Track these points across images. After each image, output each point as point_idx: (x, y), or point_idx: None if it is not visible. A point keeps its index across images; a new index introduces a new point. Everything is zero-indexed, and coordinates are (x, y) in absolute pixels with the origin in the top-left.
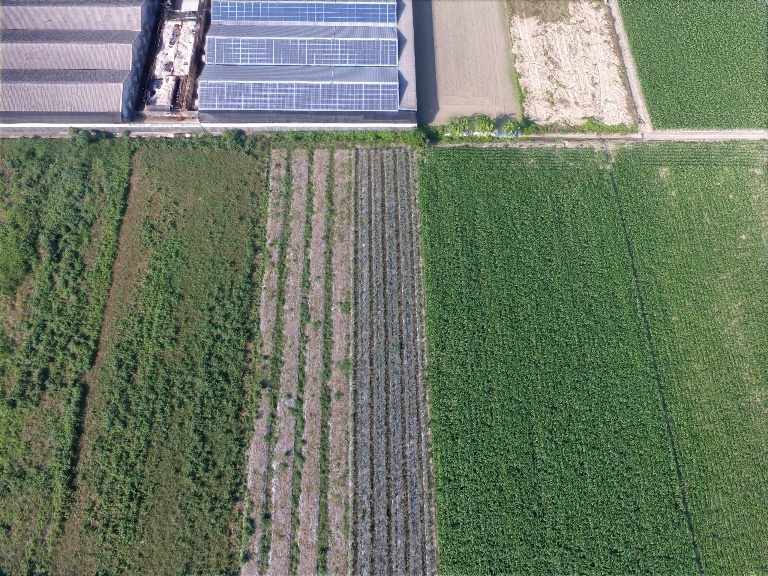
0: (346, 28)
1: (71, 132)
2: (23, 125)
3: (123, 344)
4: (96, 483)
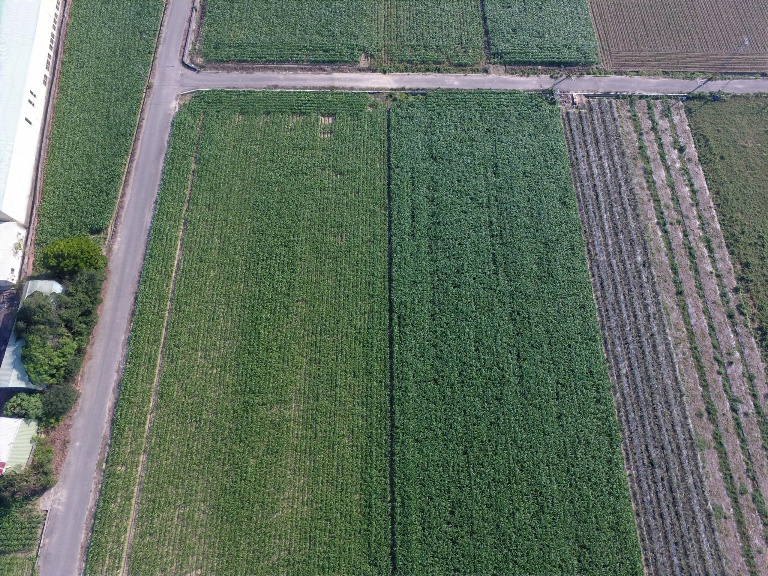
0: None
1: None
2: None
3: None
4: None
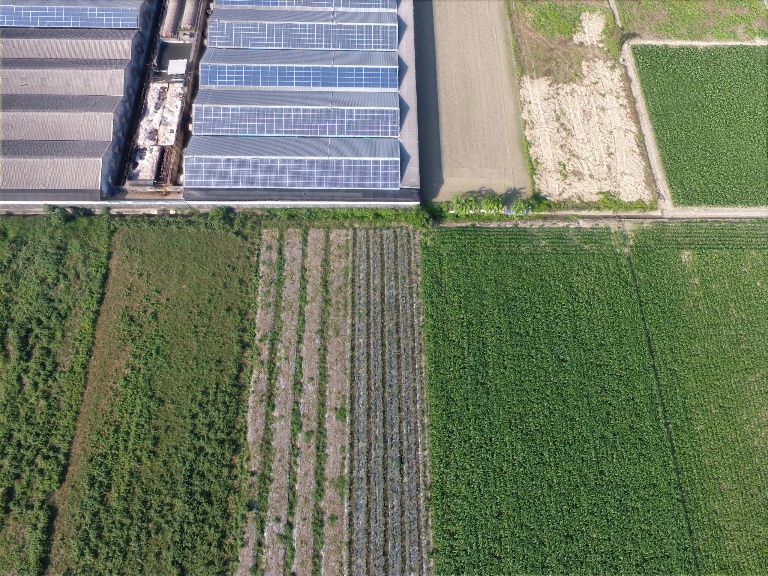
0: (344, 94)
1: (46, 210)
2: None
3: (96, 458)
4: None
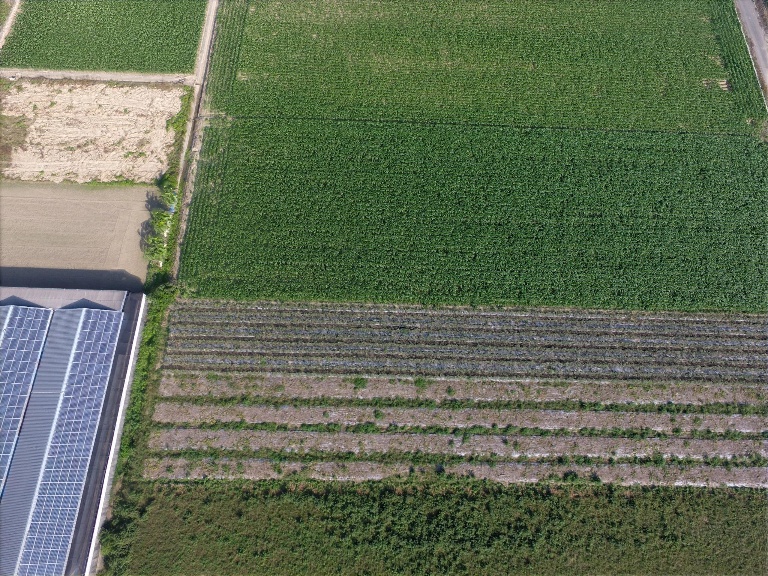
0: None
1: None
2: None
3: None
4: None
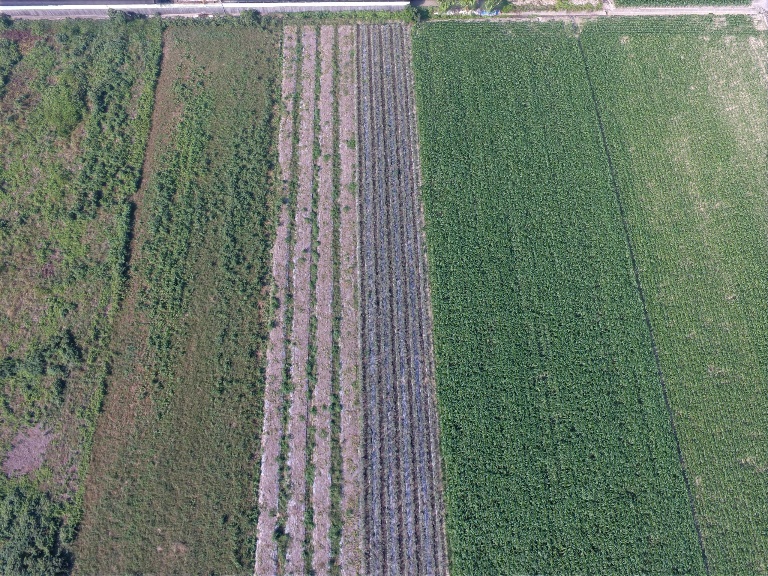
0: None
1: (110, 13)
2: (68, 7)
3: (163, 173)
4: (146, 273)
